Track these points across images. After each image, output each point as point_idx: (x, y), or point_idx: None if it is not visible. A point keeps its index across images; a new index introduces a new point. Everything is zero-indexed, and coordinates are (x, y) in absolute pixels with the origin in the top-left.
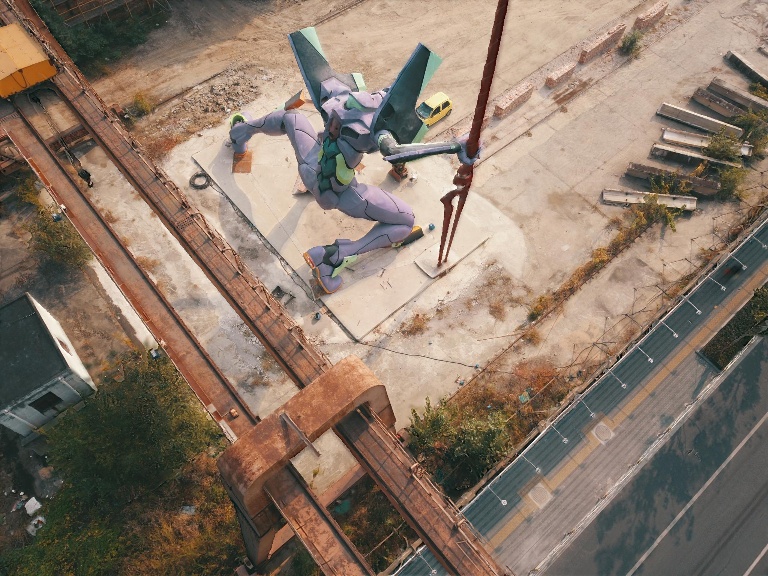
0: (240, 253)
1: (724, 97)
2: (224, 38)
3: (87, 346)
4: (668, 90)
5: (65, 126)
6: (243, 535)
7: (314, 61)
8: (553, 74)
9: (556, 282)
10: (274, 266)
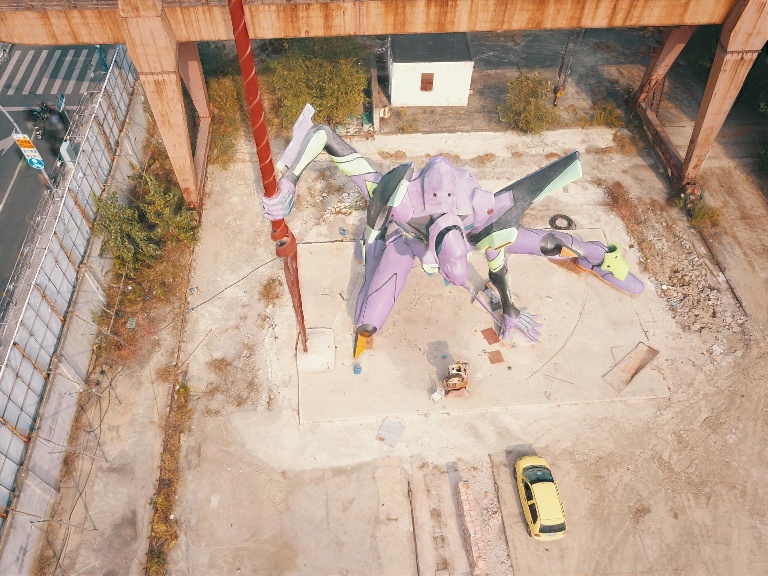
0: None
1: None
2: None
3: (433, 112)
4: None
5: None
6: None
7: (539, 182)
8: None
9: (191, 449)
10: None
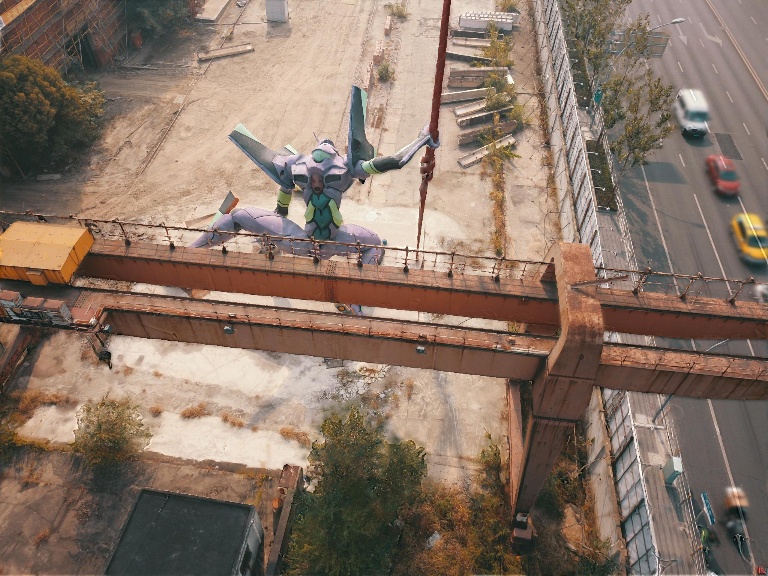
0: None
1: (463, 77)
2: None
3: None
4: (431, 89)
5: None
6: (527, 474)
7: (257, 148)
8: None
9: (489, 226)
10: None
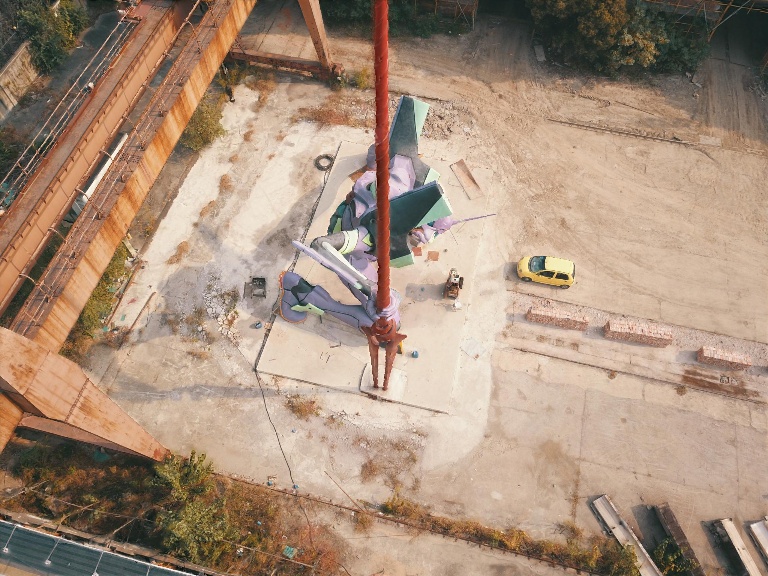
0: (279, 233)
1: None
2: (481, 77)
3: None
4: None
5: (306, 55)
6: None
7: (406, 133)
8: (712, 349)
9: (446, 510)
10: (284, 263)
